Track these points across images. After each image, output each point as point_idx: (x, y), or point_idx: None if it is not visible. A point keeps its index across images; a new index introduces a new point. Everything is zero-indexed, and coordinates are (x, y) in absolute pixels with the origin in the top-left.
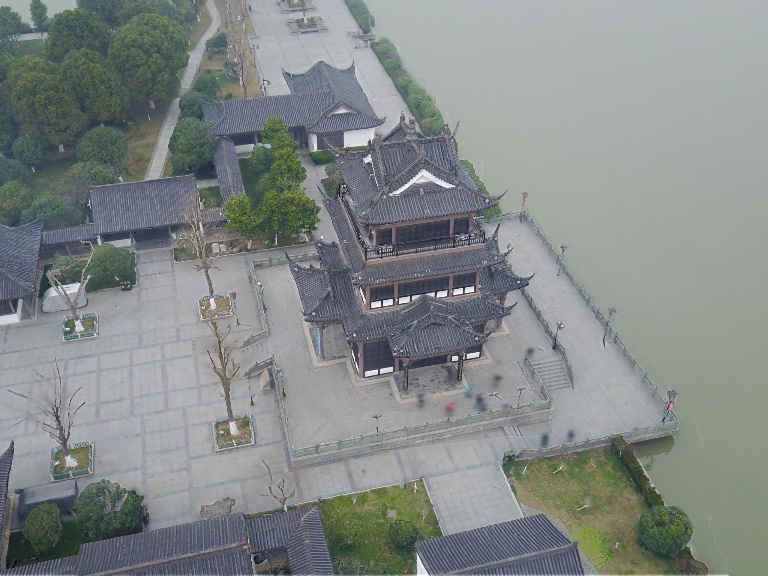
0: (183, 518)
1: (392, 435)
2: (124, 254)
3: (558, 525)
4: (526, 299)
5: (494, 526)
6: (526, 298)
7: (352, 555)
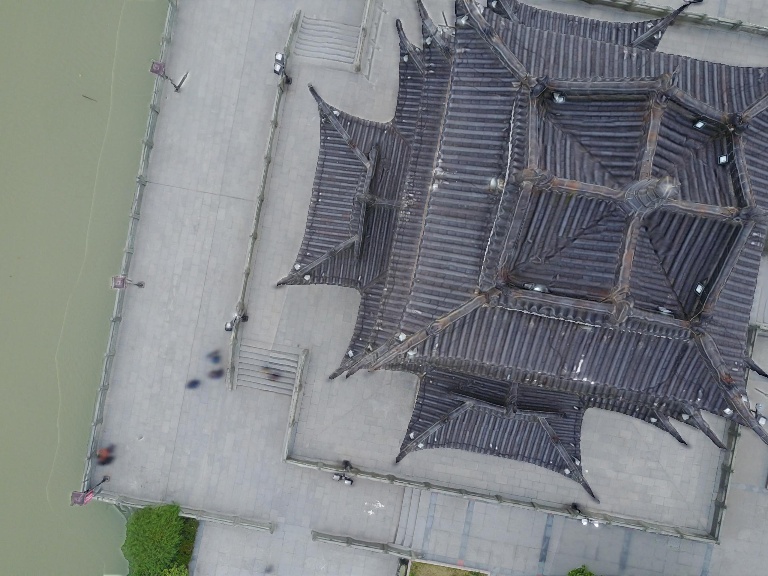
0: None
1: None
2: None
3: None
4: (259, 220)
5: None
6: (259, 221)
7: None
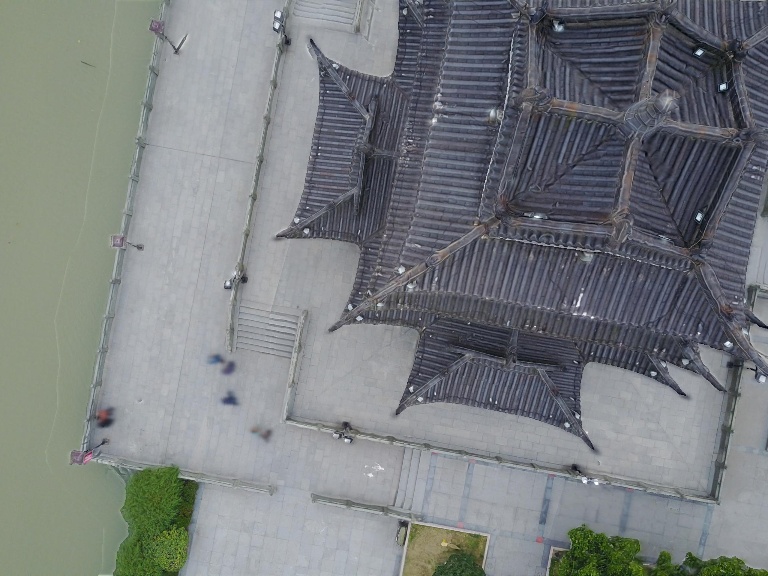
0: None
1: None
2: None
3: None
4: (259, 181)
5: None
6: (258, 182)
7: None
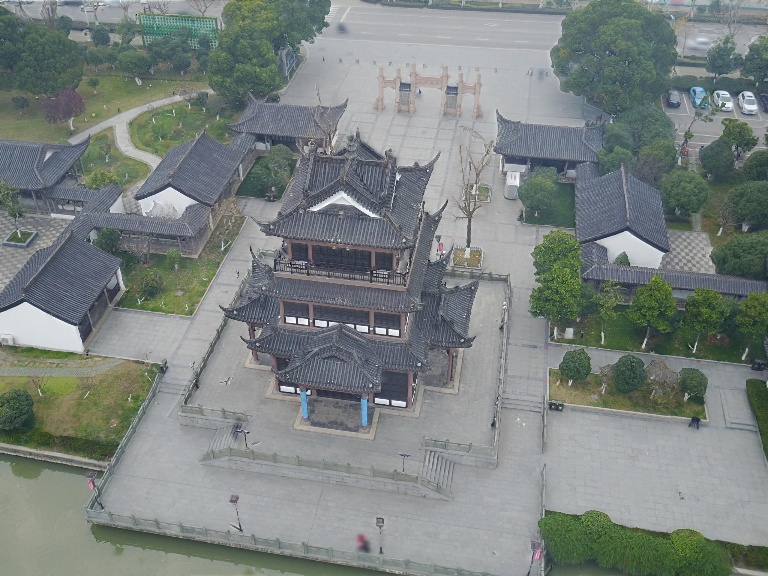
0: (259, 213)
1: (235, 302)
2: (537, 196)
3: (90, 373)
4: None
5: (96, 295)
6: None
7: (167, 267)
